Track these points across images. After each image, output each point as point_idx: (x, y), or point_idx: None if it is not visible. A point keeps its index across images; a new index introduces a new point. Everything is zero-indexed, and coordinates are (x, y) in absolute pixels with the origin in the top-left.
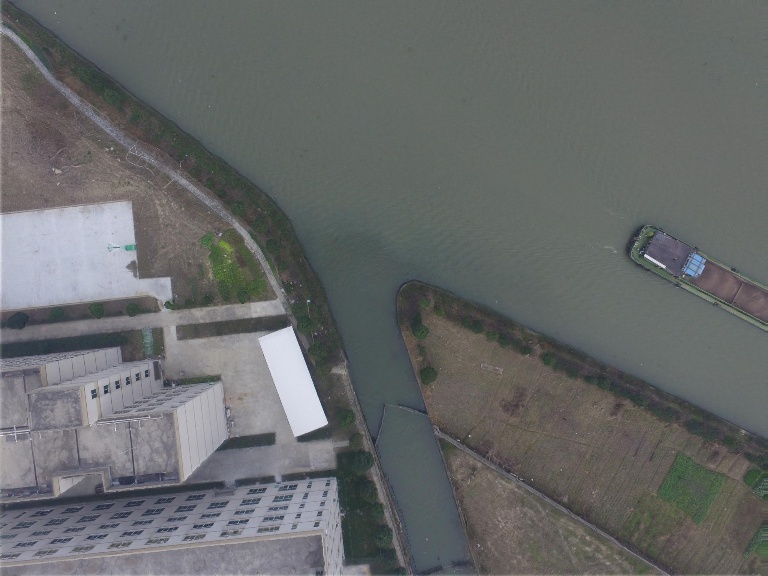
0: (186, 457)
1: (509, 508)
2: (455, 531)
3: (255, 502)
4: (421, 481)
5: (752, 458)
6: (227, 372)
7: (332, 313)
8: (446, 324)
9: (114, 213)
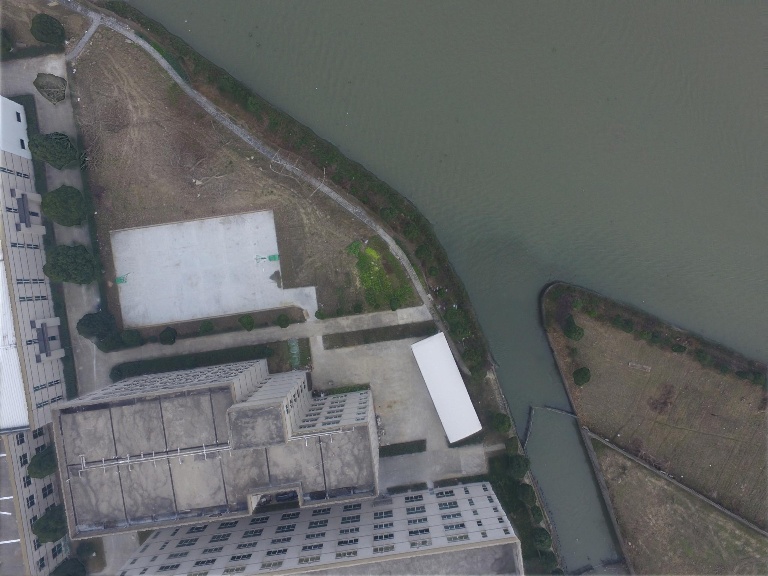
0: None
1: (659, 505)
2: (598, 530)
3: (421, 510)
4: (568, 482)
5: None
6: (375, 380)
7: (478, 317)
8: (594, 324)
9: (255, 223)
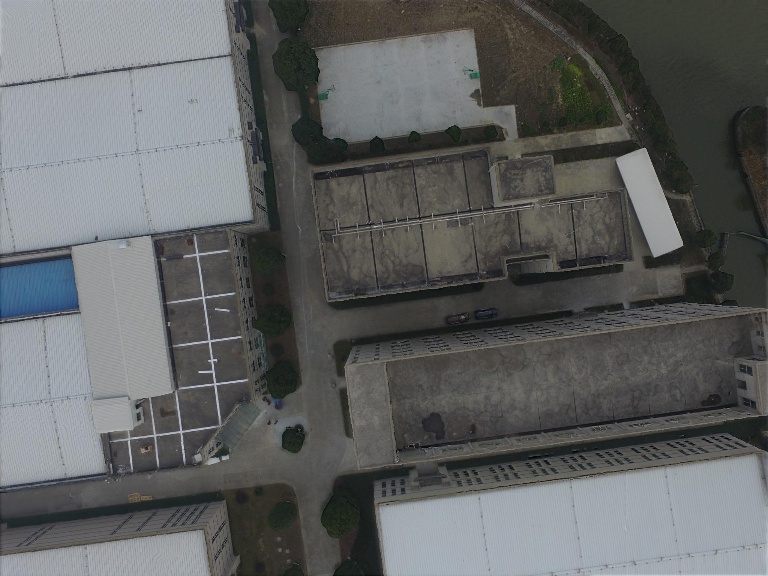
0: None
1: None
2: None
3: None
4: None
5: None
6: None
7: None
8: None
9: (456, 42)
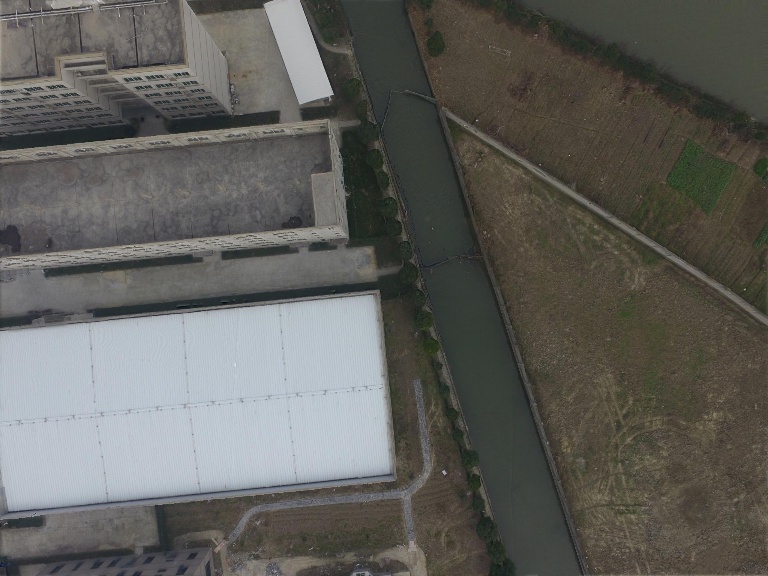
0: (191, 51)
1: (516, 194)
2: (461, 234)
3: None
4: (427, 172)
5: (763, 134)
6: (232, 49)
7: None
8: (454, 4)
9: None
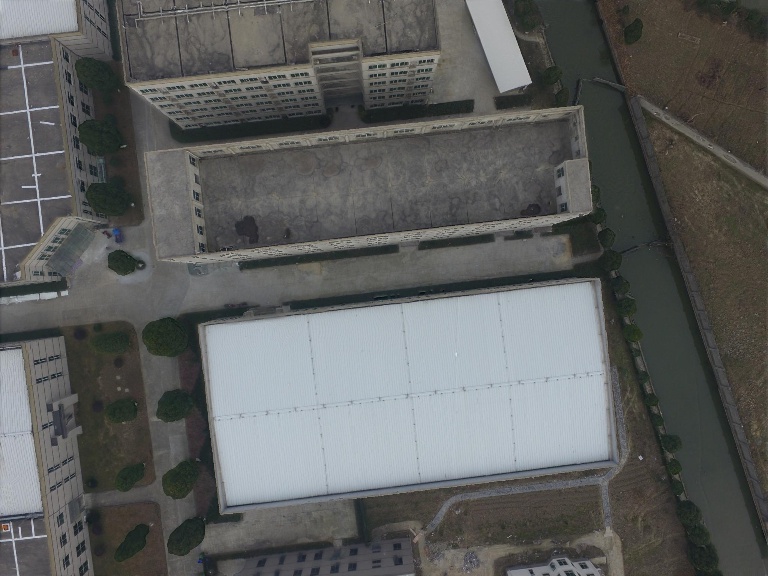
0: None
1: (706, 181)
2: (641, 222)
3: None
4: (614, 160)
5: None
6: None
7: None
8: None
9: None
